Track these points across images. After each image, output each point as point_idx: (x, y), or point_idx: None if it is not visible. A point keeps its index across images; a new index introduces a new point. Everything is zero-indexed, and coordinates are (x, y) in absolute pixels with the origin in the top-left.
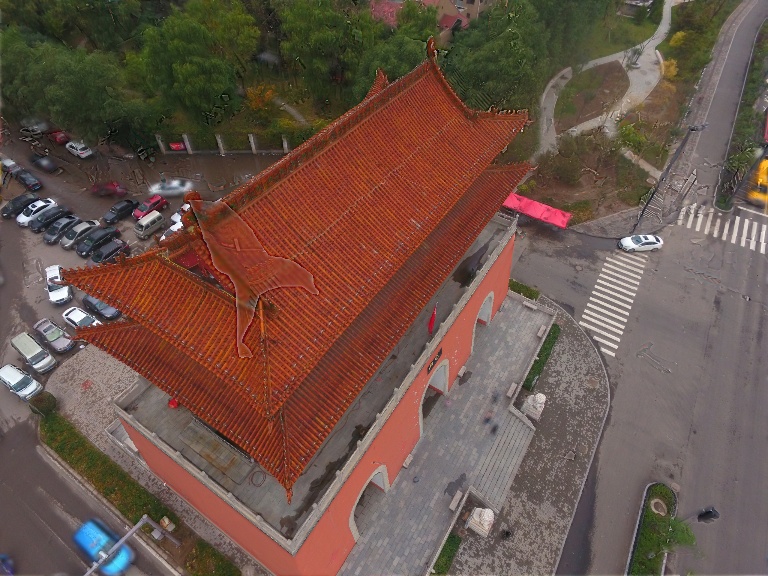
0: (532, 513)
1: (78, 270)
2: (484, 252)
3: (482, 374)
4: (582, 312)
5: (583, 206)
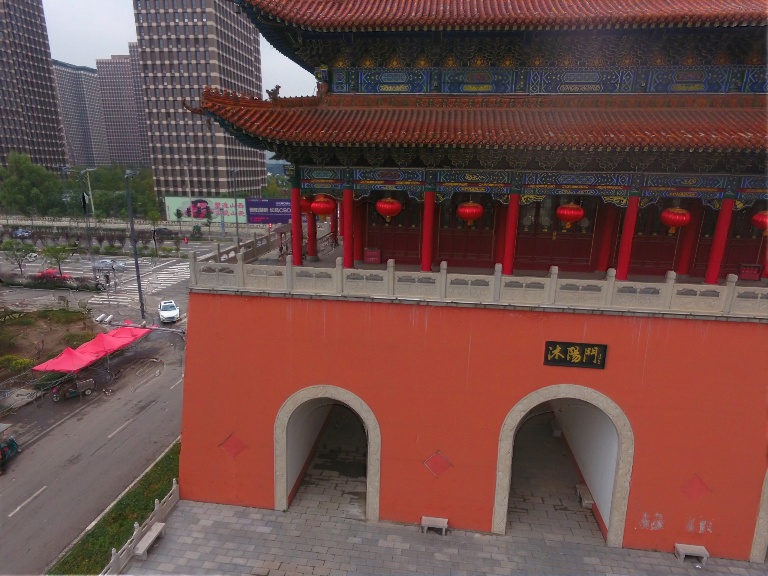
0: None
1: None
2: None
3: None
4: None
5: (81, 337)
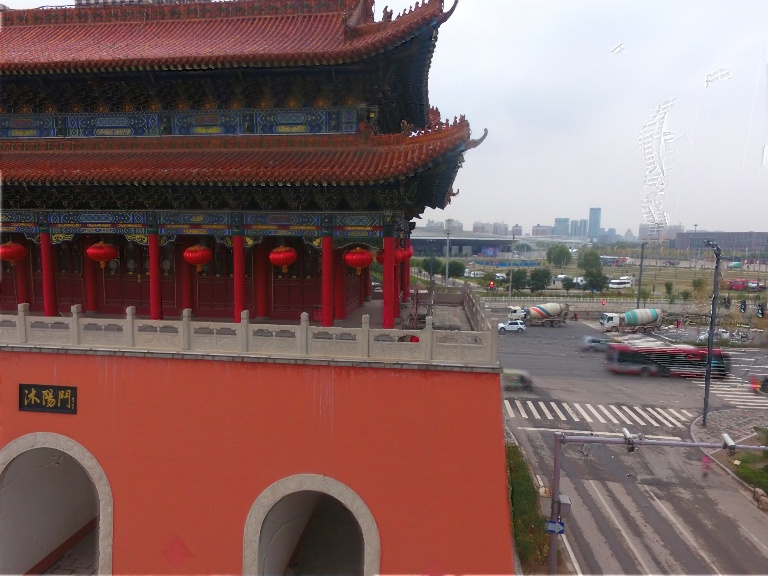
0: None
1: (425, 5)
2: None
3: None
4: None
5: None
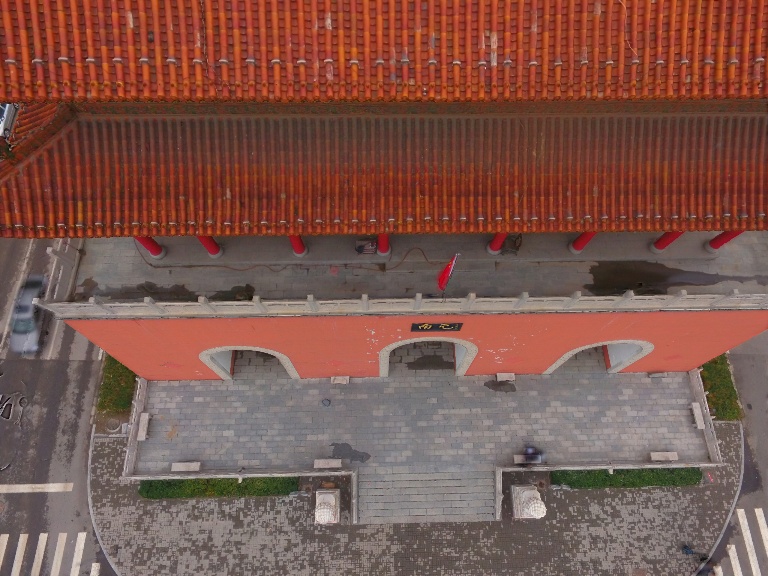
0: (381, 568)
1: None
2: (697, 282)
3: (523, 405)
4: (765, 505)
5: None
